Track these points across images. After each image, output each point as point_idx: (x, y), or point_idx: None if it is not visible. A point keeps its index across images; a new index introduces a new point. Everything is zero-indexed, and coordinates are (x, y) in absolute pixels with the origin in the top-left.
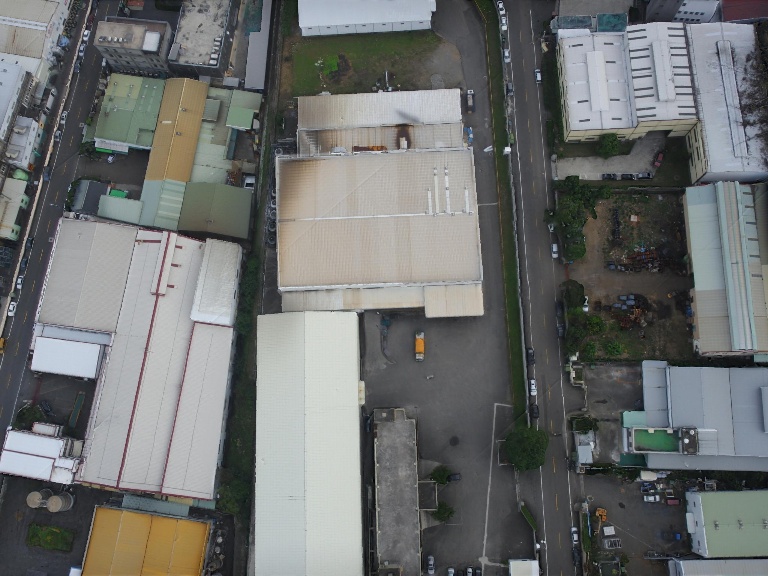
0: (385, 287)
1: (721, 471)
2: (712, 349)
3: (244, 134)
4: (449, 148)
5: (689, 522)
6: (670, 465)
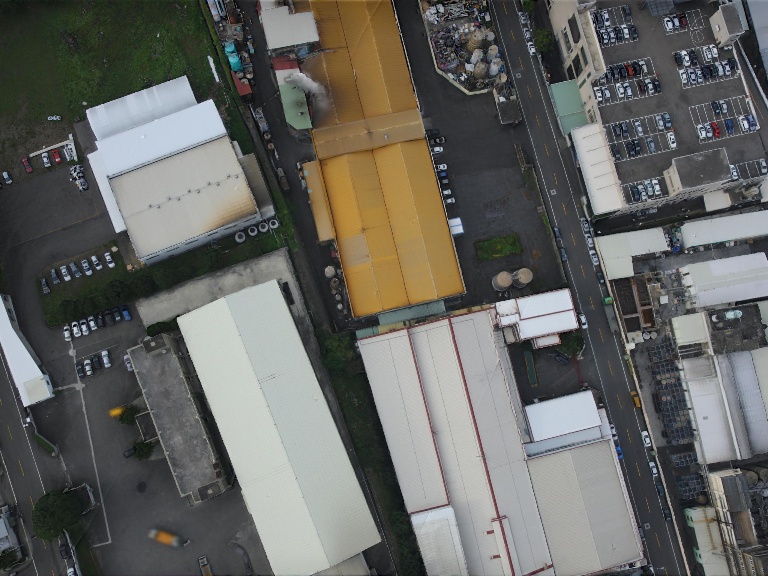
0: None
1: None
2: None
3: None
4: None
5: None
6: None
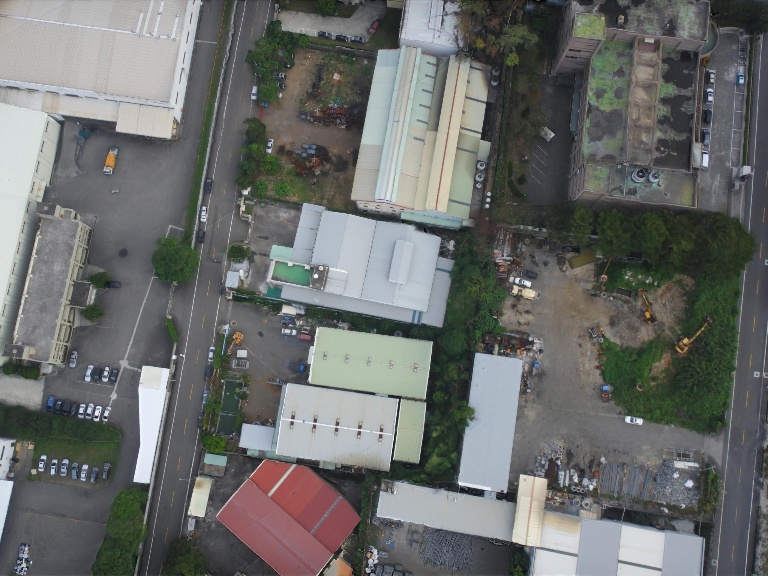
0: (84, 97)
1: (348, 313)
2: (360, 198)
3: None
4: None
5: (310, 354)
6: (301, 298)
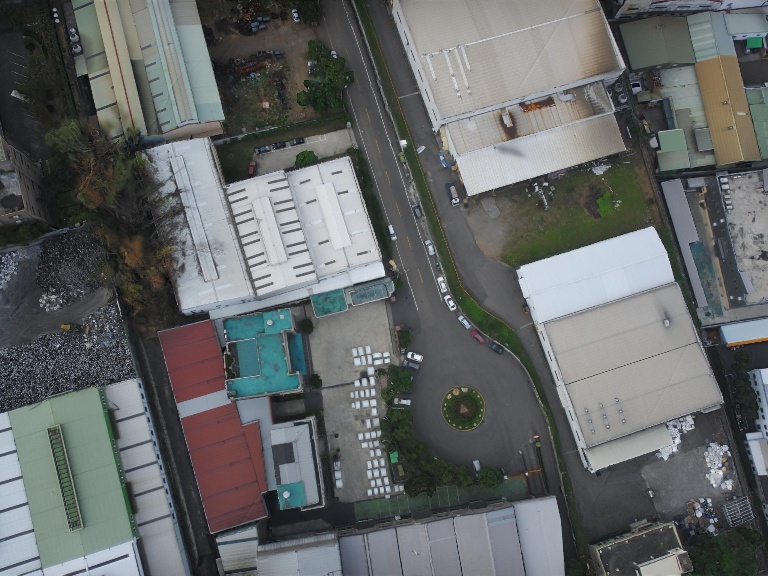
0: None
1: None
2: None
3: None
4: (463, 114)
5: None
6: None
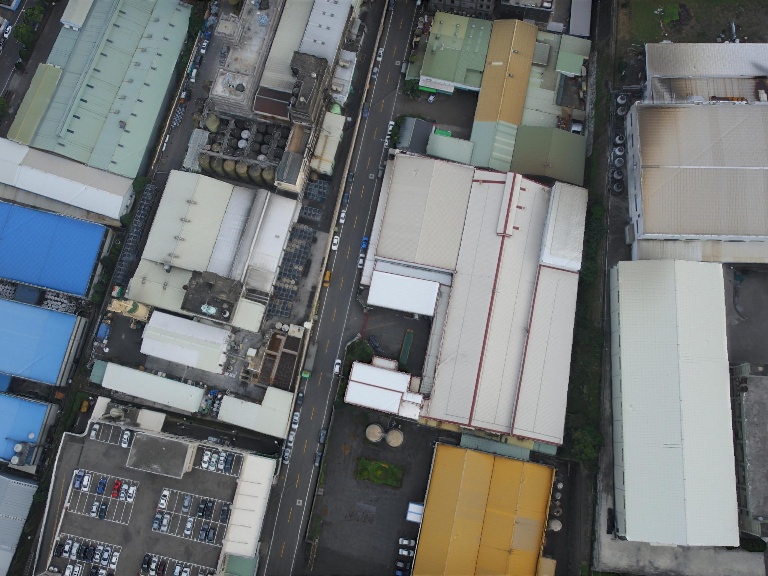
0: (747, 241)
1: None
2: None
3: (569, 81)
4: None
5: None
6: None
